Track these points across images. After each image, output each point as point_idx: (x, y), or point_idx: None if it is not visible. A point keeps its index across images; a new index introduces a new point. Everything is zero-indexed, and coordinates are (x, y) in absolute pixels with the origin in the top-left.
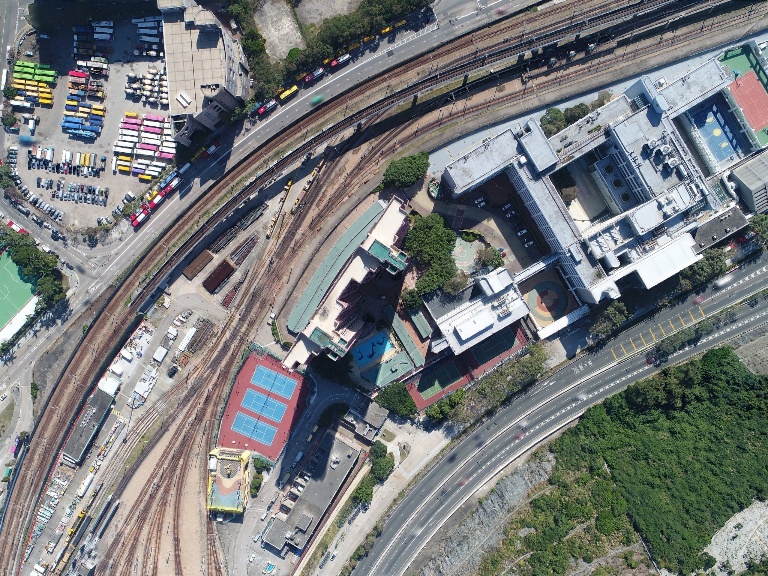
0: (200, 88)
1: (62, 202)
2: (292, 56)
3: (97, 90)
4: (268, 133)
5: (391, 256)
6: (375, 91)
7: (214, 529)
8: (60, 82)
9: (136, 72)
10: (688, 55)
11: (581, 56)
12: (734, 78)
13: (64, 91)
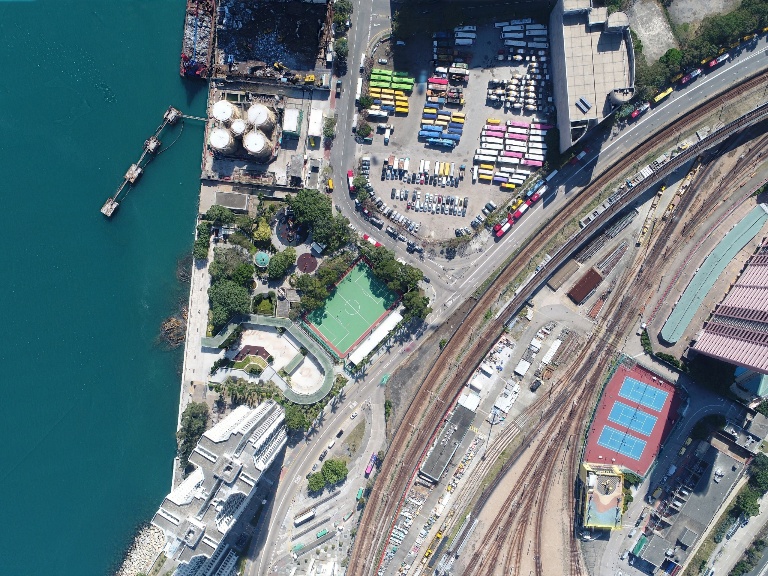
0: (613, 92)
1: (417, 213)
2: (675, 57)
3: (457, 97)
4: (637, 137)
5: None
6: (753, 91)
7: (578, 547)
8: (416, 90)
9: (497, 77)
10: None
11: None
12: None
13: (420, 99)
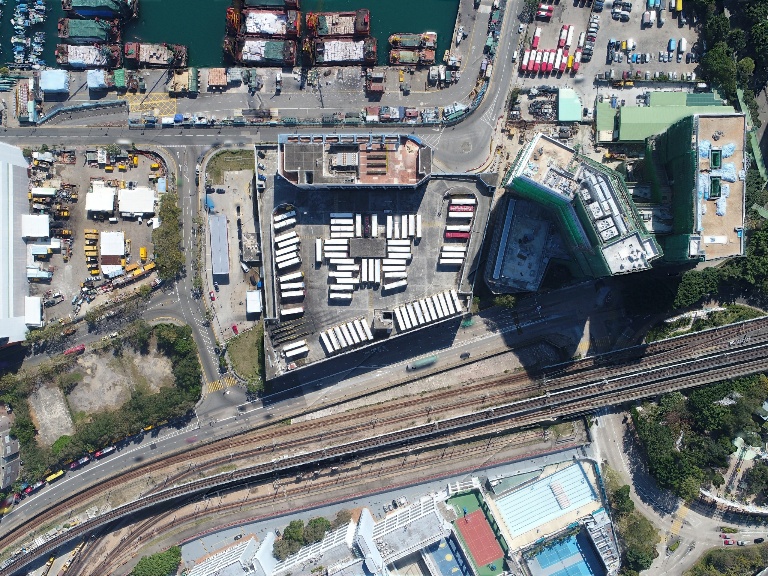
0: None
1: None
2: (55, 450)
3: None
4: (36, 508)
5: None
6: (137, 481)
7: None
8: None
9: None
10: (428, 480)
11: (328, 471)
12: (463, 514)
13: None
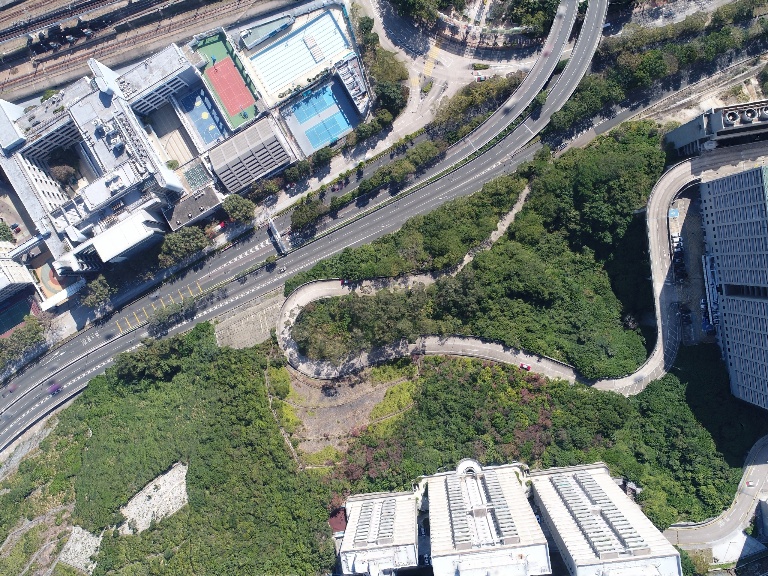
0: None
1: None
2: None
3: None
4: None
5: None
6: None
7: None
8: None
9: None
10: (182, 41)
11: (83, 41)
12: (212, 64)
13: None
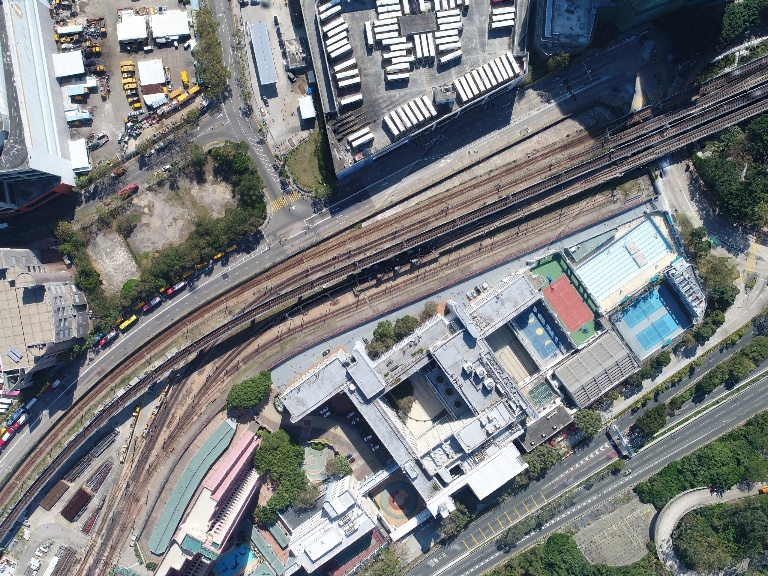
0: (27, 349)
1: None
2: (126, 291)
3: None
4: (112, 361)
5: (203, 548)
6: (214, 313)
7: None
8: None
9: None
10: (507, 260)
11: (407, 268)
12: (548, 283)
13: None
